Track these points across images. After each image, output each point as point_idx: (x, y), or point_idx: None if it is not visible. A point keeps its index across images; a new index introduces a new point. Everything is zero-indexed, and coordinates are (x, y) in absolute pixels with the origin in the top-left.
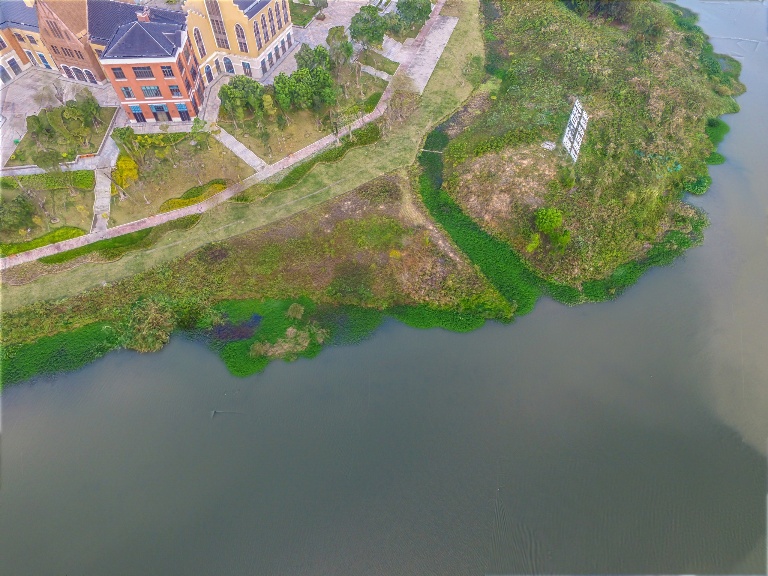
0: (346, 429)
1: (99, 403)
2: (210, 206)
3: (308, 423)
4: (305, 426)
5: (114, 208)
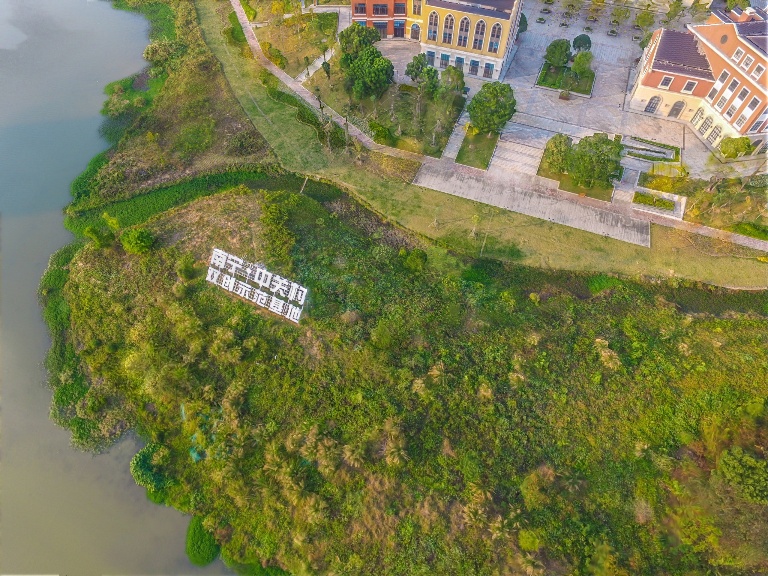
0: (40, 124)
1: (121, 45)
2: (260, 62)
3: (58, 111)
4: (56, 110)
5: (268, 25)
